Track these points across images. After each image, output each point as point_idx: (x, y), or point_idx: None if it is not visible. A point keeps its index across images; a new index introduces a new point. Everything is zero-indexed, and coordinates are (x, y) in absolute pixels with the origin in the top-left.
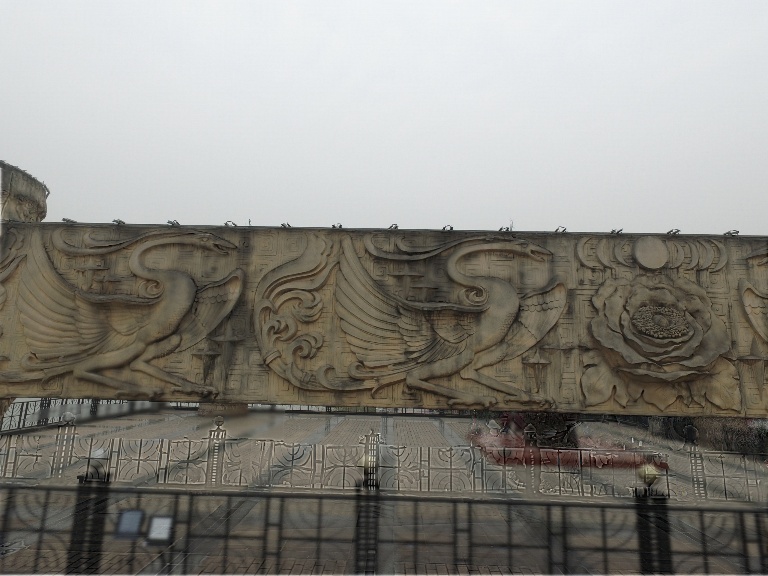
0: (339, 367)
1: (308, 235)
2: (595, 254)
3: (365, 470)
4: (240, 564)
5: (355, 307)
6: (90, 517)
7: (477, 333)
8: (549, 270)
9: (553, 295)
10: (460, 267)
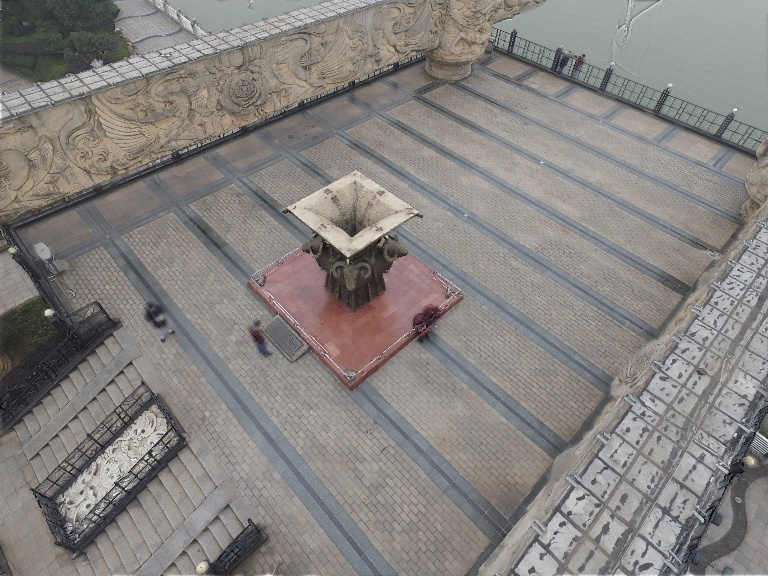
0: None
1: None
2: None
3: None
4: (669, 301)
5: None
6: None
7: None
8: None
9: None
10: None
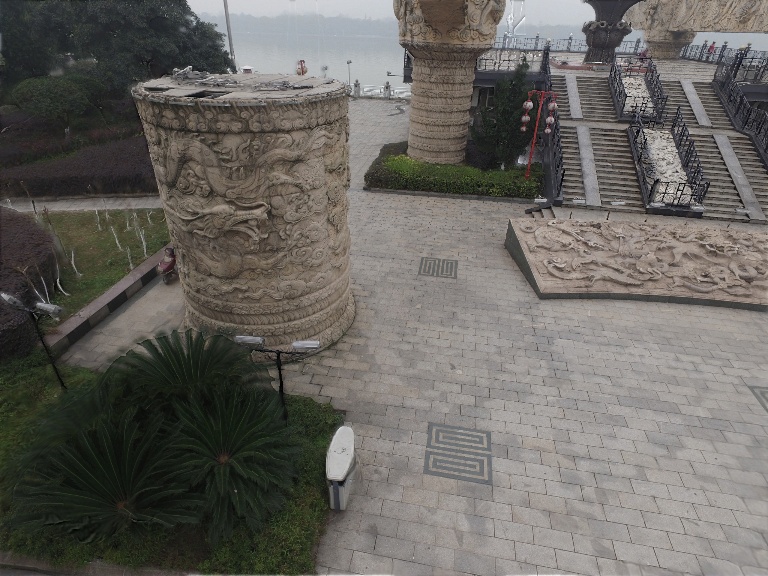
0: None
1: None
2: None
3: None
4: None
5: (713, 5)
6: None
7: None
8: None
9: None
10: None
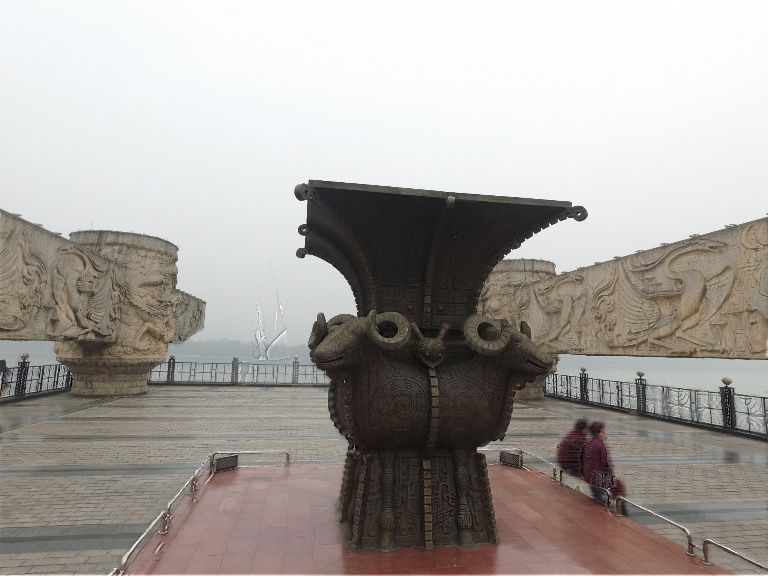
0: (623, 334)
1: (606, 266)
2: (755, 237)
3: (724, 412)
4: (588, 423)
5: None
6: (574, 409)
7: (679, 308)
8: (725, 257)
9: (725, 275)
10: (672, 267)
